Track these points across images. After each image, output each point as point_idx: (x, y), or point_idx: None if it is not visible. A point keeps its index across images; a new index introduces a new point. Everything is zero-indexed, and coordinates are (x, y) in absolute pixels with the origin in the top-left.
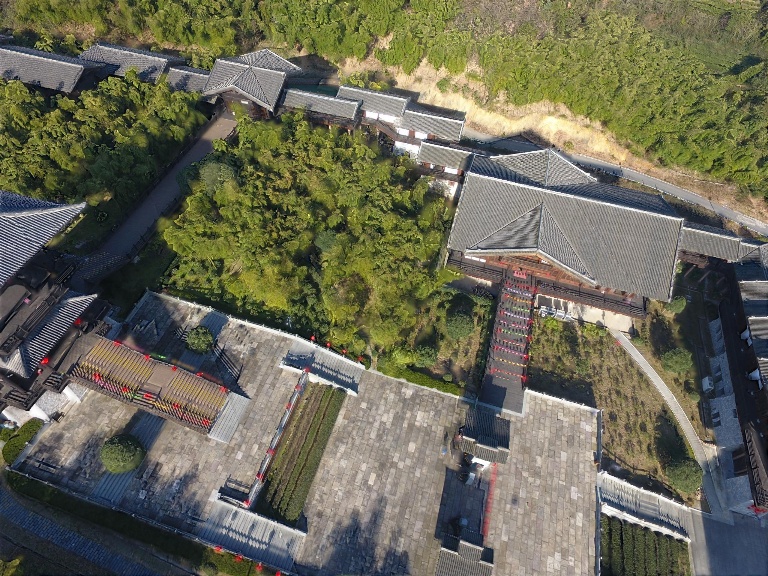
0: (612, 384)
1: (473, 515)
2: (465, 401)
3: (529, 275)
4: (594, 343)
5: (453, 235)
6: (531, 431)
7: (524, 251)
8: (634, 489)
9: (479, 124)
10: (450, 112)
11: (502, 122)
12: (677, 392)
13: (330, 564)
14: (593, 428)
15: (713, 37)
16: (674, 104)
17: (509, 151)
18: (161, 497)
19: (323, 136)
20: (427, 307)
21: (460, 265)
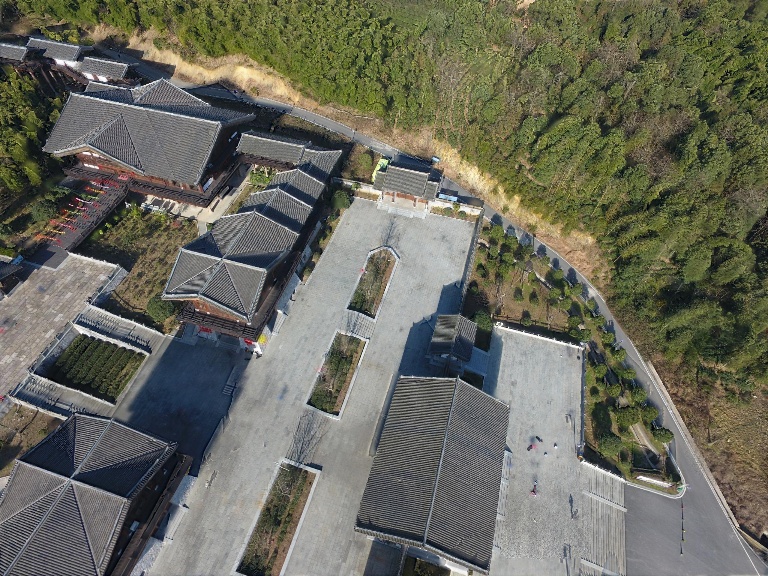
0: (161, 255)
1: None
2: None
3: (131, 178)
4: (173, 229)
5: (49, 141)
6: (55, 280)
7: (81, 147)
8: (119, 319)
9: (185, 75)
10: (165, 66)
11: (203, 72)
12: None
13: None
14: None
15: (413, 1)
16: (322, 50)
17: (200, 95)
18: None
19: (1, 76)
20: None
21: (78, 171)
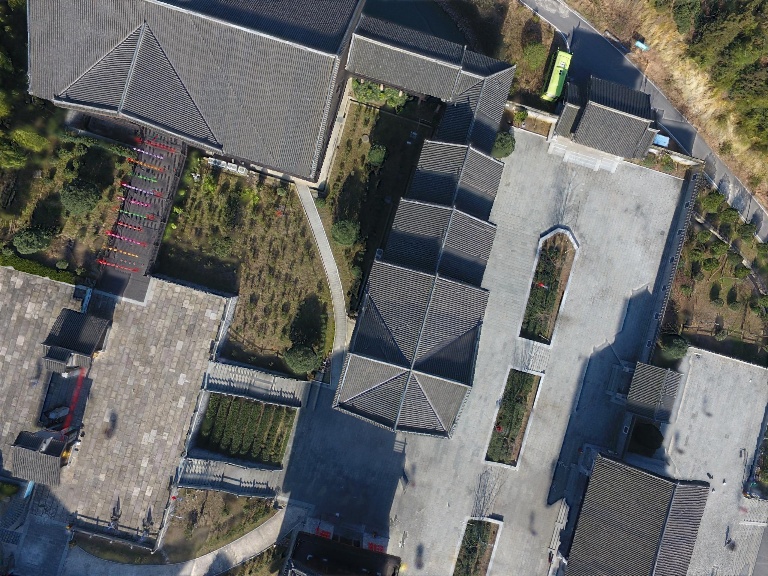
0: (269, 259)
1: (78, 401)
2: (83, 290)
3: None
4: (268, 206)
5: (32, 74)
6: (150, 321)
7: (107, 112)
8: None
9: None
10: None
11: None
12: (343, 265)
13: None
14: (218, 316)
15: None
16: None
17: None
18: None
19: None
20: (52, 167)
21: None
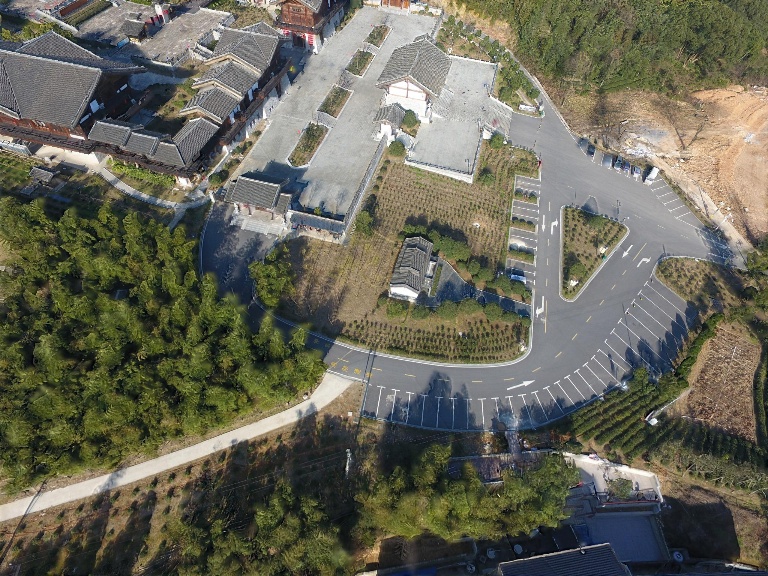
0: None
1: None
2: None
3: None
4: None
5: None
6: None
7: None
8: None
9: None
10: None
11: None
12: None
13: (85, 37)
14: None
15: None
16: None
17: None
18: (14, 10)
19: None
20: None
21: None
